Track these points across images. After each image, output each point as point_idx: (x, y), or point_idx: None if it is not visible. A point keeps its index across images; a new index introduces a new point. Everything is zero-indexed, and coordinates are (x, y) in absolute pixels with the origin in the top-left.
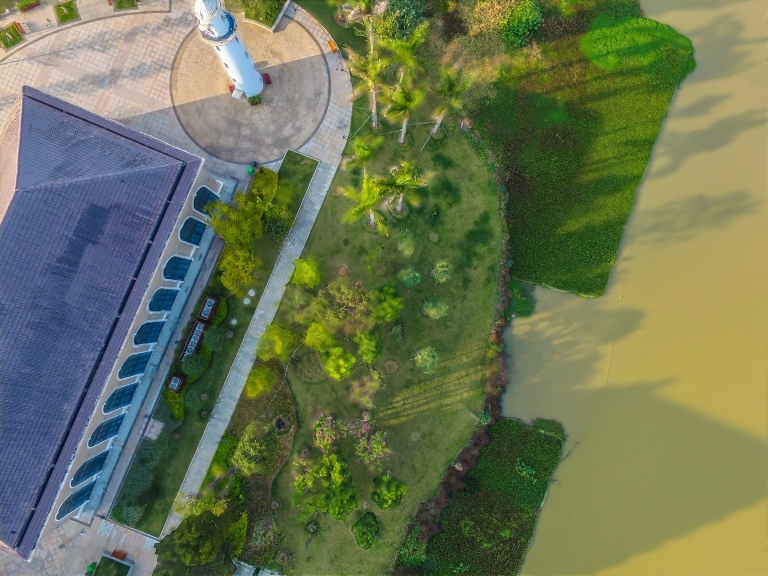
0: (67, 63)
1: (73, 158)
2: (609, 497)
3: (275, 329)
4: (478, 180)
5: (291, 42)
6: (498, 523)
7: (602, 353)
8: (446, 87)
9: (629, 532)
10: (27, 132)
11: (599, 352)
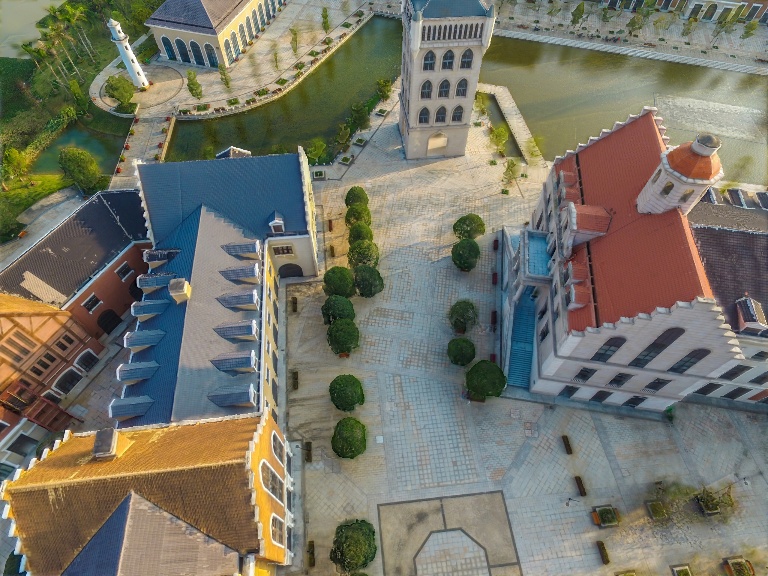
0: (234, 87)
1: (182, 1)
2: (24, 13)
3: (135, 6)
4: (40, 82)
5: (117, 100)
6: (76, 5)
7: (5, 44)
8: (28, 47)
9: (20, 6)
10: (202, 7)
11: (7, 44)
